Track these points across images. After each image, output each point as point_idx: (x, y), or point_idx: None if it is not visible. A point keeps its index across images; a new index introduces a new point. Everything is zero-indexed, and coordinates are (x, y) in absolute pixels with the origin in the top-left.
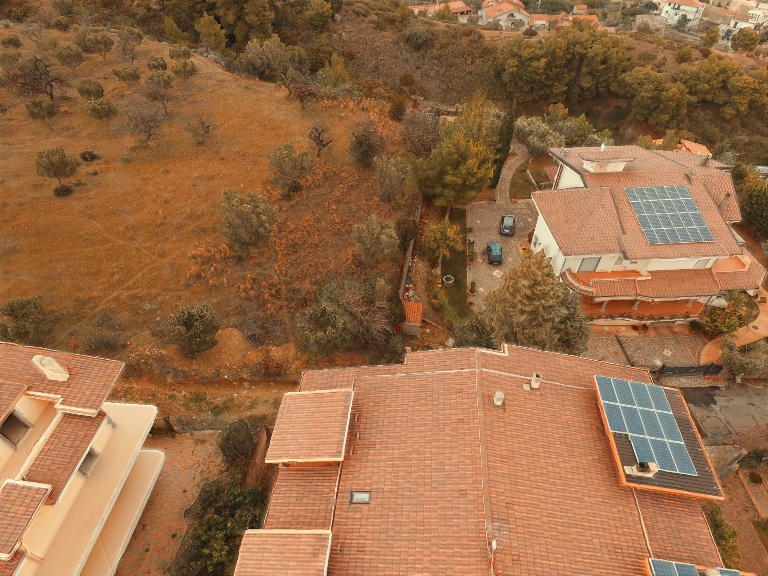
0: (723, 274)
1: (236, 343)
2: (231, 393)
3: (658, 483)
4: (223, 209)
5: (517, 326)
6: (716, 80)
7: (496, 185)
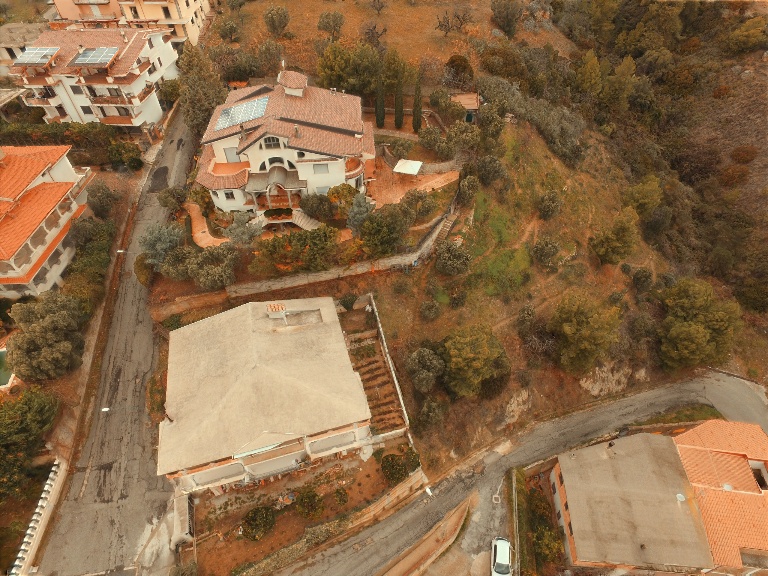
0: None
1: None
2: None
3: (77, 54)
4: (271, 5)
5: None
6: None
7: (381, 127)
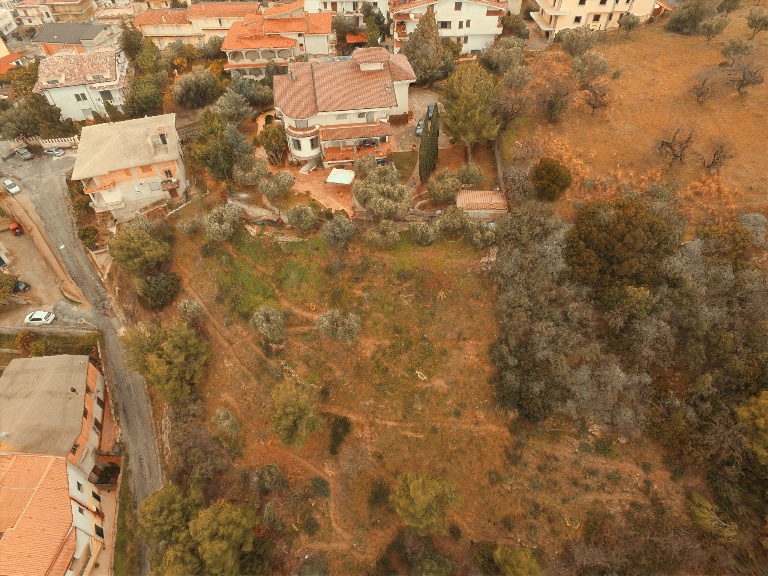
0: None
1: None
2: None
3: None
4: None
5: None
6: None
7: None
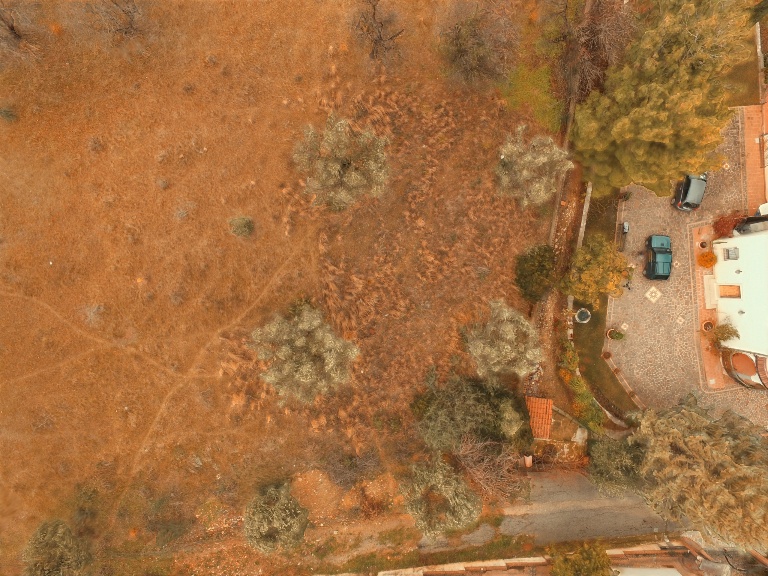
0: None
1: (325, 492)
2: (330, 531)
3: None
4: None
5: None
6: None
7: None
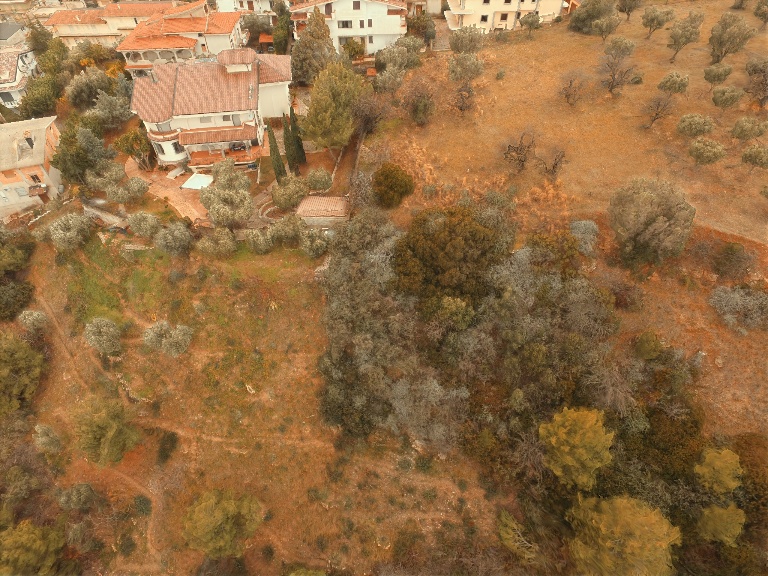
0: None
1: None
2: None
3: None
4: None
5: None
6: None
7: (298, 163)
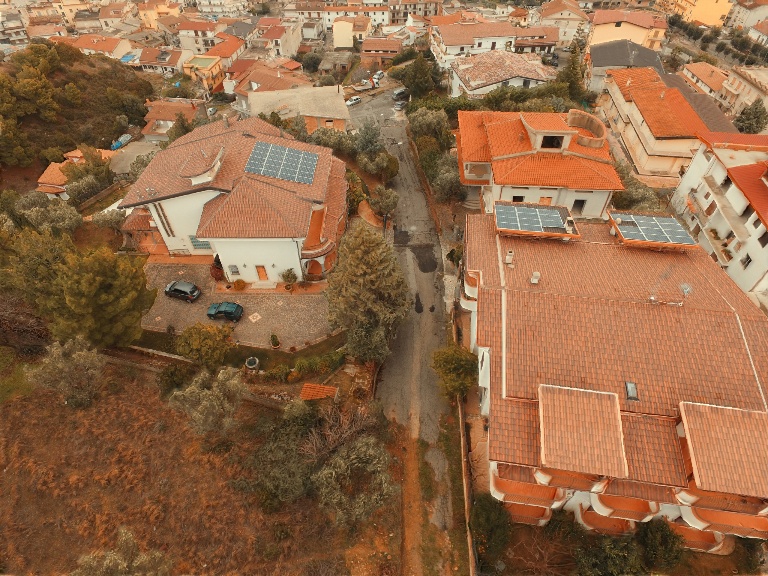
0: (332, 171)
1: None
2: None
3: None
4: None
5: (386, 290)
6: (5, 96)
7: None
